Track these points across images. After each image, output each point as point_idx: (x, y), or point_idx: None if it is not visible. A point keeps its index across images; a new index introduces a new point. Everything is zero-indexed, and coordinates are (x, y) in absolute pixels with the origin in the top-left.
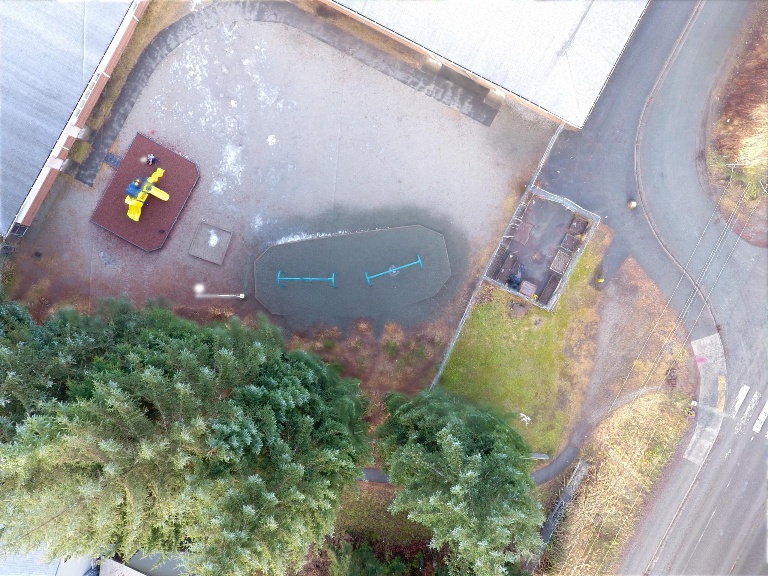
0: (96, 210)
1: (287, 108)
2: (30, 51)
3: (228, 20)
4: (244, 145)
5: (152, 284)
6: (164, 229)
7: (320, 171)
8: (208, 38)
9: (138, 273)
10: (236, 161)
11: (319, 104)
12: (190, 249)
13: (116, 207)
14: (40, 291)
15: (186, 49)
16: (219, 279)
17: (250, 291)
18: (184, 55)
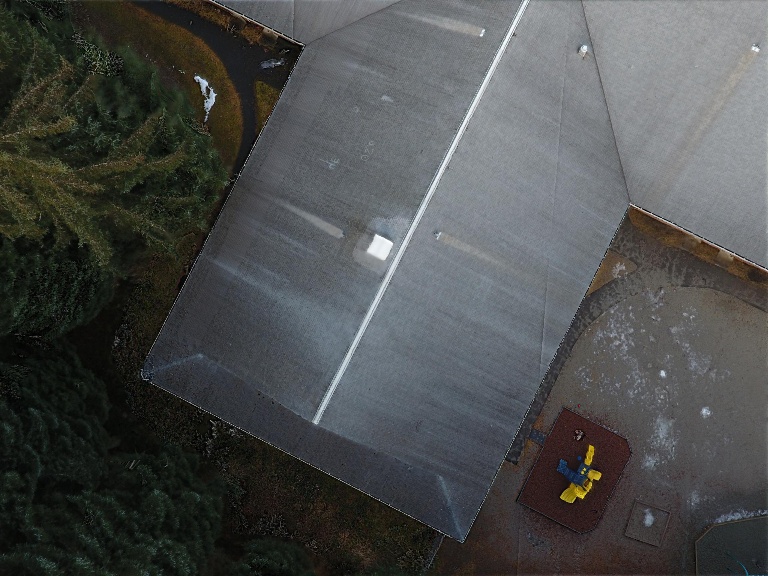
0: (523, 490)
1: (720, 378)
2: (495, 354)
3: (654, 286)
4: (676, 418)
5: (583, 566)
6: (596, 509)
7: (759, 444)
8: (633, 305)
9: (568, 555)
10: (668, 435)
11: (755, 373)
12: (626, 531)
13: (543, 486)
14: (465, 575)
15: (610, 317)
16: (655, 560)
17: (688, 572)
18: (608, 324)
